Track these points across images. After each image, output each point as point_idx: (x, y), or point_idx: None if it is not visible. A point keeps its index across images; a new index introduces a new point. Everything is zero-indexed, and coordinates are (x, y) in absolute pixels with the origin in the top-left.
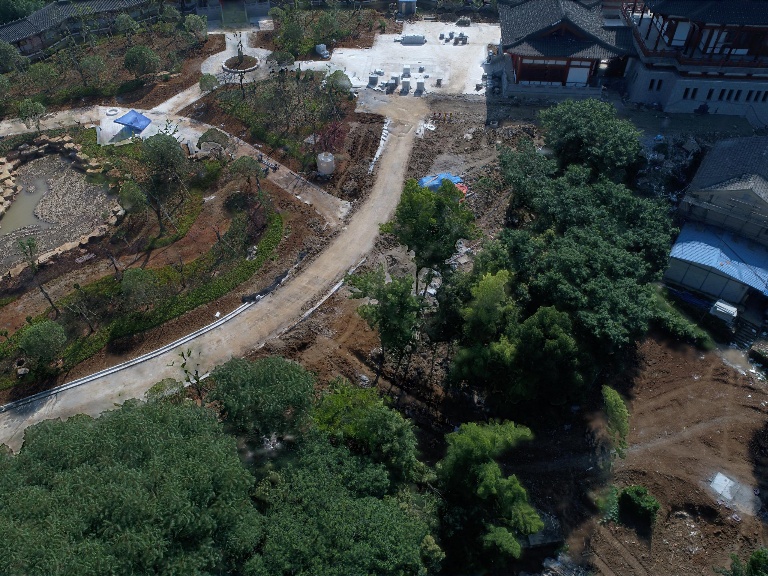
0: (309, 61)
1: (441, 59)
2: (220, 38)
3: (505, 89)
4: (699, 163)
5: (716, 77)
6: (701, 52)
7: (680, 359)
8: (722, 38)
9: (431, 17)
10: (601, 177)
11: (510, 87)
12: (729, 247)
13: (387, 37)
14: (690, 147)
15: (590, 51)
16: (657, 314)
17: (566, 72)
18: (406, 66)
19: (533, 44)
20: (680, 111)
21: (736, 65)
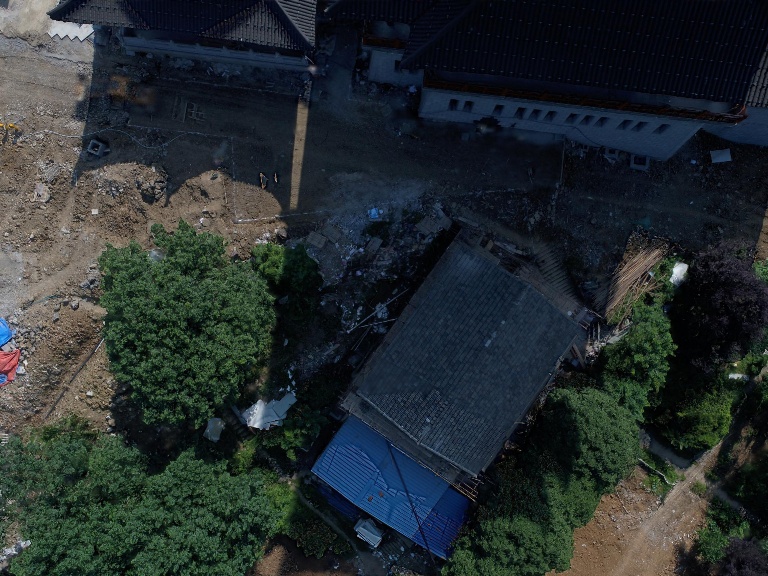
0: None
1: None
2: None
3: None
4: None
5: None
6: None
7: (306, 572)
8: None
9: None
10: None
11: (129, 40)
12: (396, 464)
13: None
14: (427, 228)
15: (248, 20)
16: (285, 531)
17: None
18: None
19: None
20: (448, 119)
21: (535, 97)
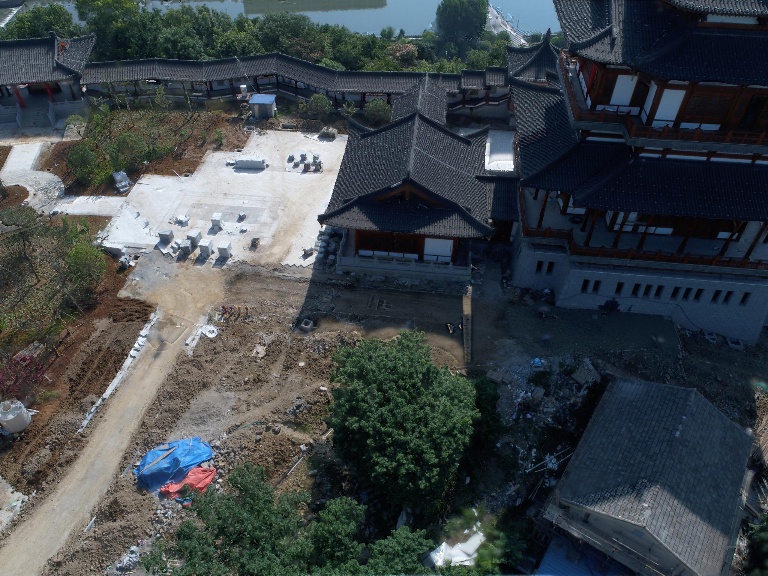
0: (98, 197)
1: (276, 198)
2: (2, 153)
3: (337, 262)
4: (596, 401)
5: (627, 266)
6: (606, 228)
7: None
8: (632, 217)
9: (291, 123)
10: (351, 569)
11: (344, 260)
12: None
13: (220, 157)
14: (583, 377)
15: (446, 224)
16: None
17: (421, 243)
18: (215, 216)
19: (366, 210)
20: (579, 306)
21: (651, 258)
